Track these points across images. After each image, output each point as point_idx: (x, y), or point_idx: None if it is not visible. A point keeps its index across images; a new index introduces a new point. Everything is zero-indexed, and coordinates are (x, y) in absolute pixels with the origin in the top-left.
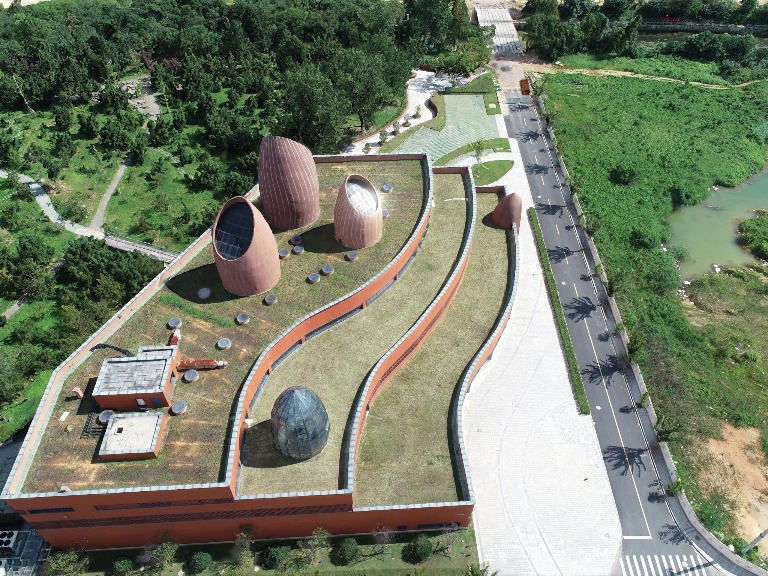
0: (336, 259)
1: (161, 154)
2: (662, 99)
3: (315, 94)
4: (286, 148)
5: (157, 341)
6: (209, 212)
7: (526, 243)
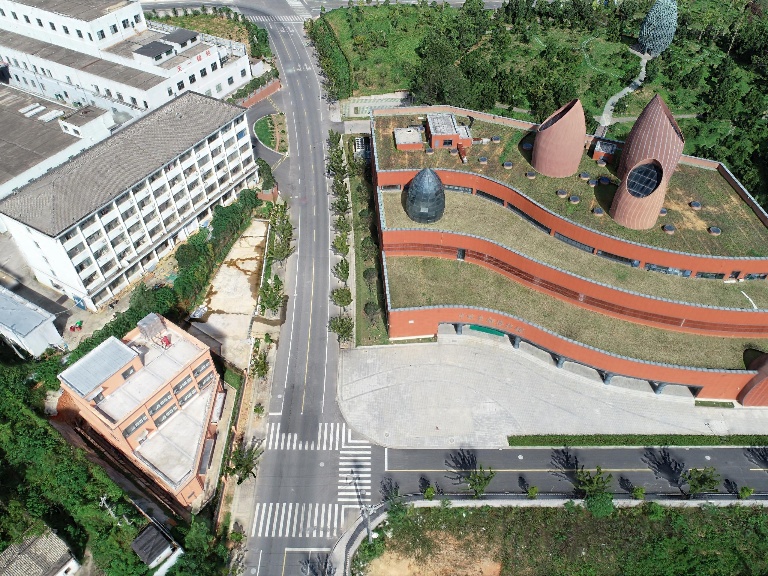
0: (592, 205)
1: (727, 130)
2: None
3: None
4: (653, 109)
5: (480, 137)
6: None
7: (767, 424)
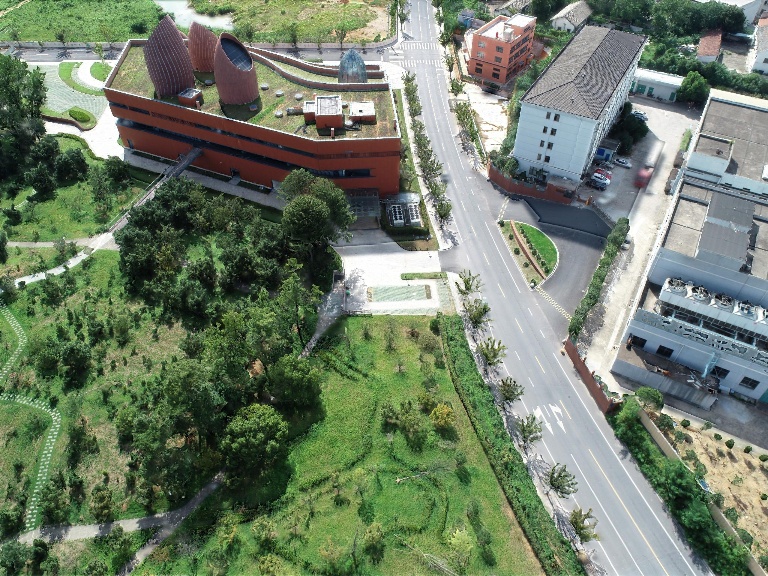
0: None
1: None
2: (53, 6)
3: (17, 68)
4: None
5: (292, 119)
6: (118, 159)
7: None
